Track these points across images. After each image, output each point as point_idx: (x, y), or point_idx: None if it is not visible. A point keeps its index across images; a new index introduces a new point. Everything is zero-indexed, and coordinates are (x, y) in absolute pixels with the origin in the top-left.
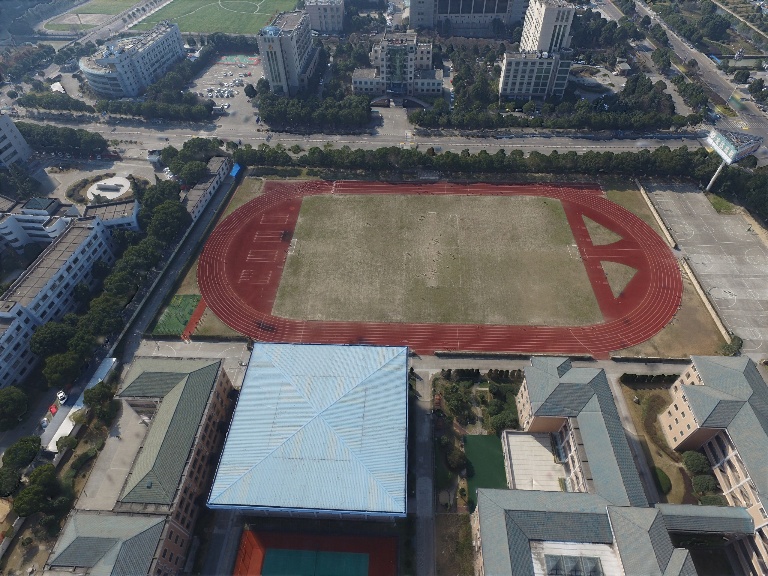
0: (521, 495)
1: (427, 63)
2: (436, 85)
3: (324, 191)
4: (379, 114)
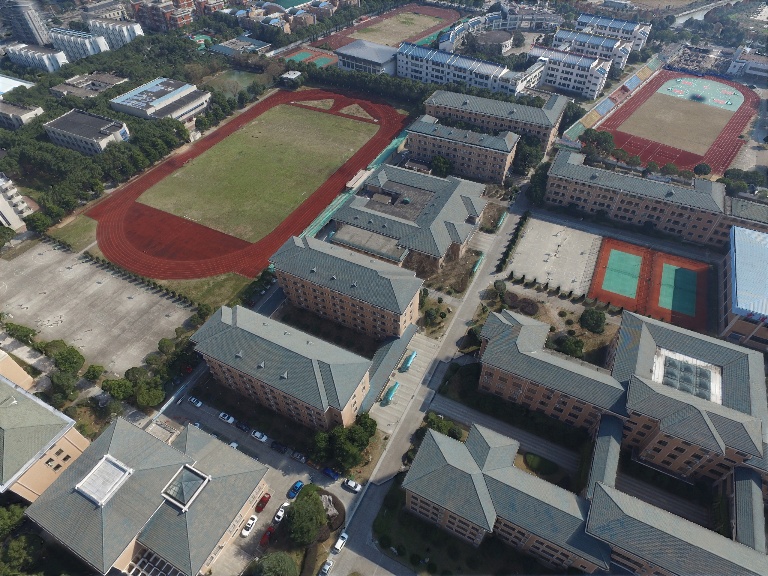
0: (761, 375)
1: None
2: None
3: None
4: None
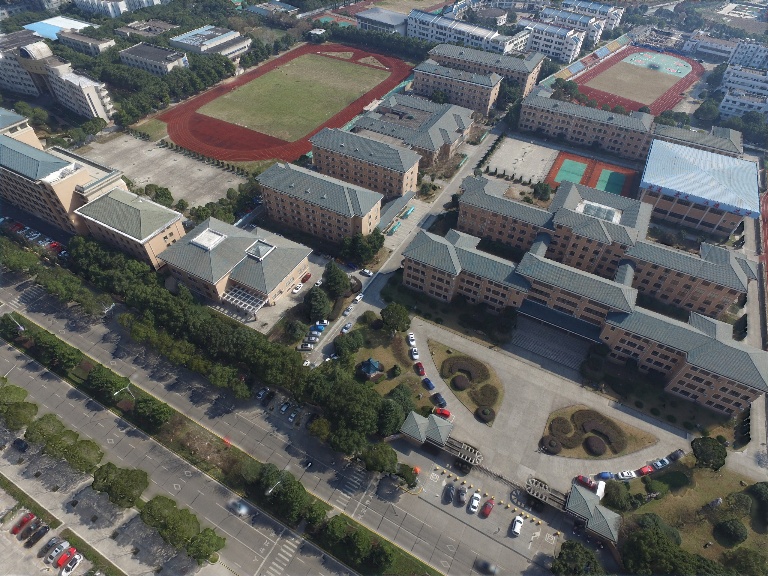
0: None
1: None
2: None
3: None
4: None
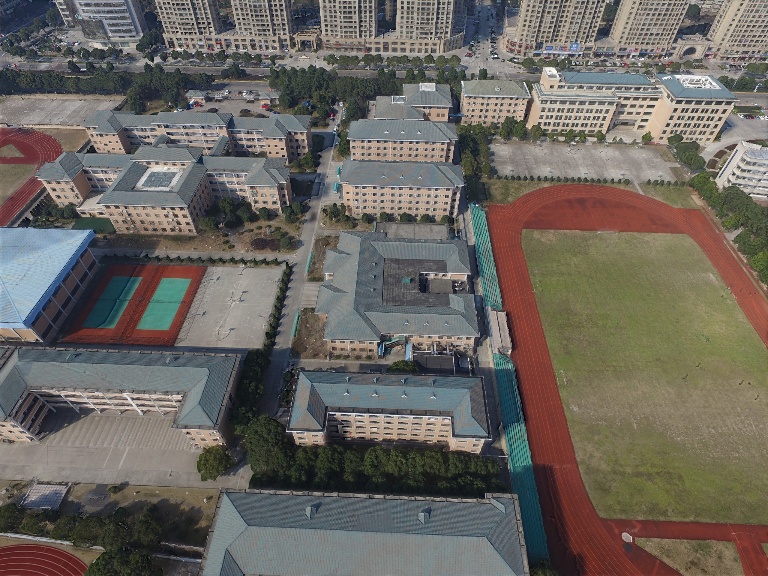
0: None
1: None
2: None
3: None
4: None
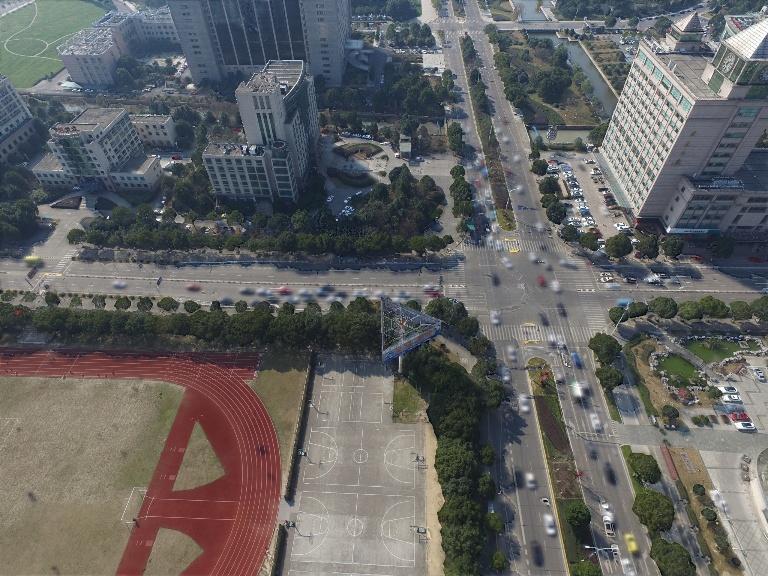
0: None
1: (166, 139)
2: (139, 180)
3: None
4: (50, 223)
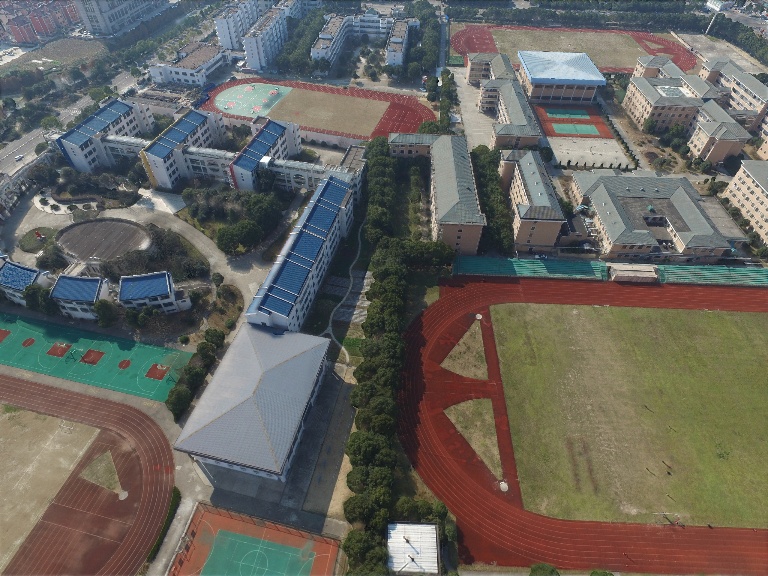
0: None
1: None
2: None
3: (500, 28)
4: (513, 2)
